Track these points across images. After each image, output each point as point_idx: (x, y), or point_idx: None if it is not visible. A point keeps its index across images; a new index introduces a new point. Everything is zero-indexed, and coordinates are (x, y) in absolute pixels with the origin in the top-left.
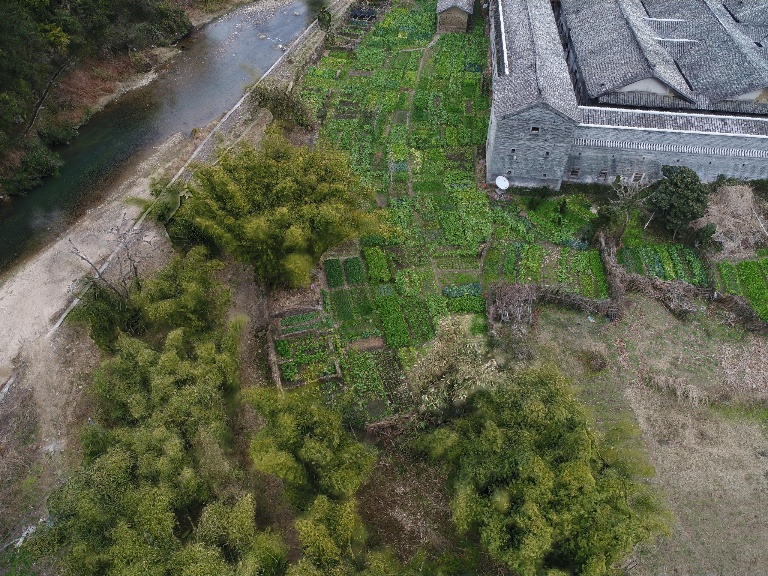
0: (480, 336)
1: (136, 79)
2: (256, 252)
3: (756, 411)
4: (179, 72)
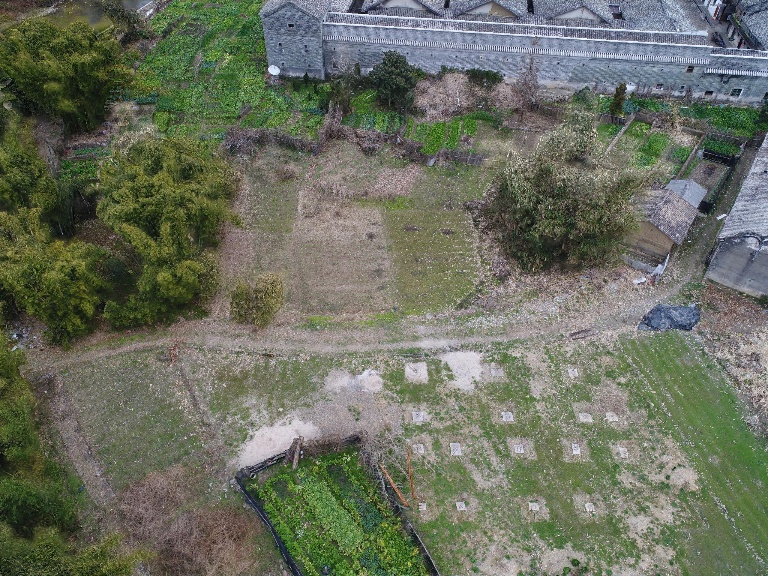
0: None
1: (37, 11)
2: (42, 91)
3: (384, 202)
4: (74, 7)
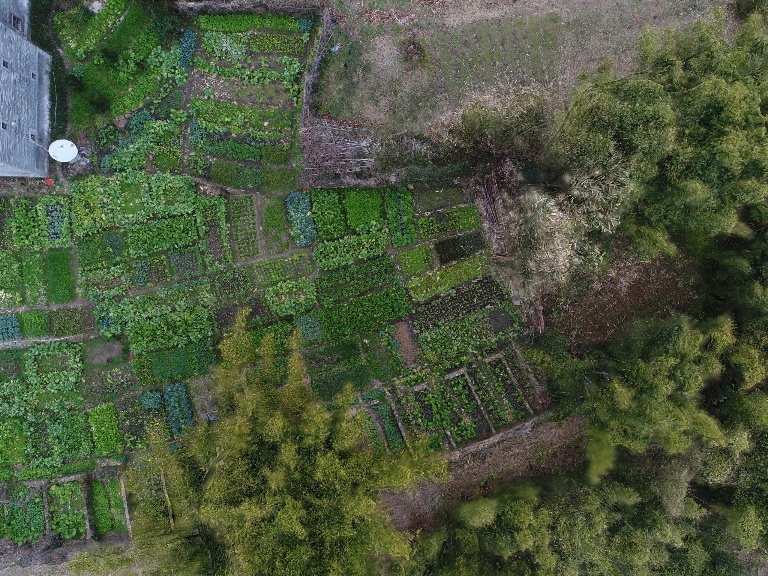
0: (380, 197)
1: None
2: None
3: None
4: None
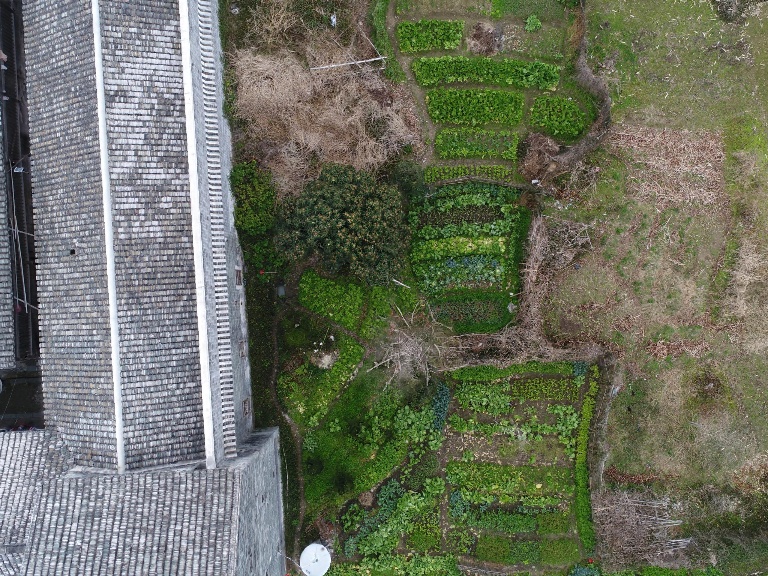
0: None
1: None
2: None
3: (759, 175)
4: None
